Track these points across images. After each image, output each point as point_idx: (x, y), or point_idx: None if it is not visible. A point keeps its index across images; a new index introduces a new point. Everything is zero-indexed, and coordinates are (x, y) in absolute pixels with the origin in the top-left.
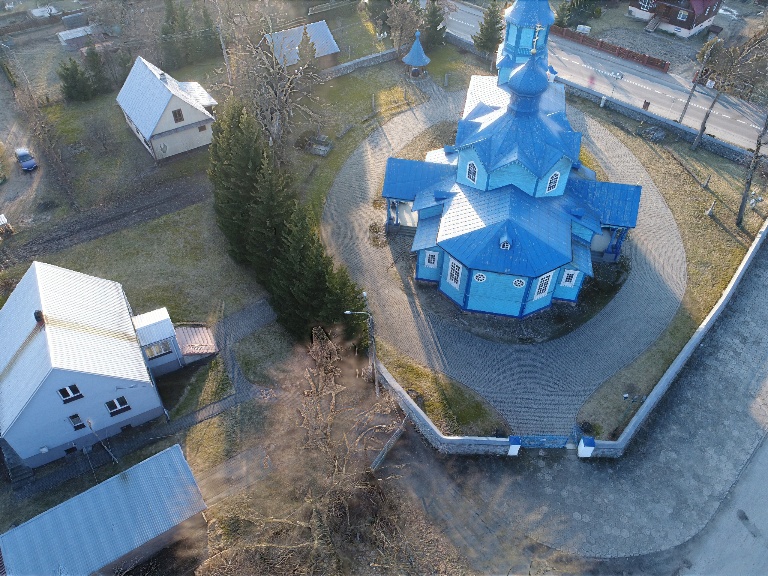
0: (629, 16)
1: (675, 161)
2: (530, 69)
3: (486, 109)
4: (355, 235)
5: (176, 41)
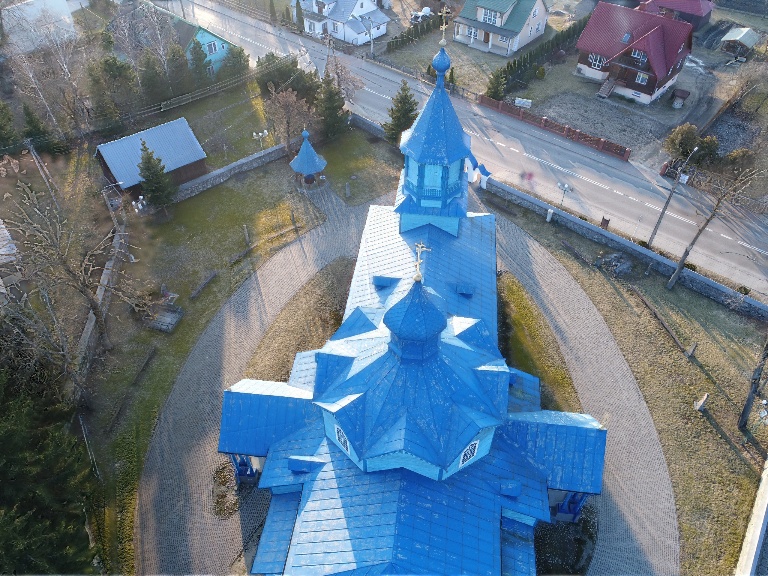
0: (578, 75)
1: (647, 310)
2: (415, 303)
3: (365, 322)
4: (191, 492)
5: None
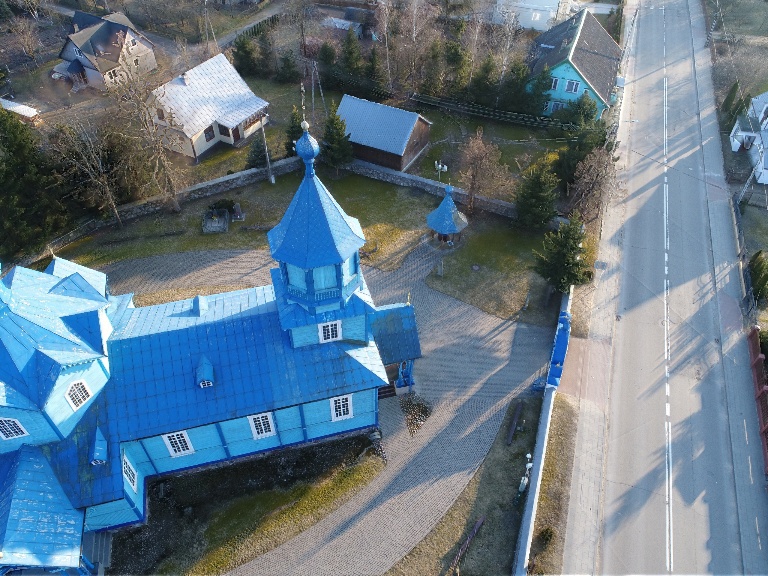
0: None
1: None
2: None
3: None
4: None
5: (336, 63)
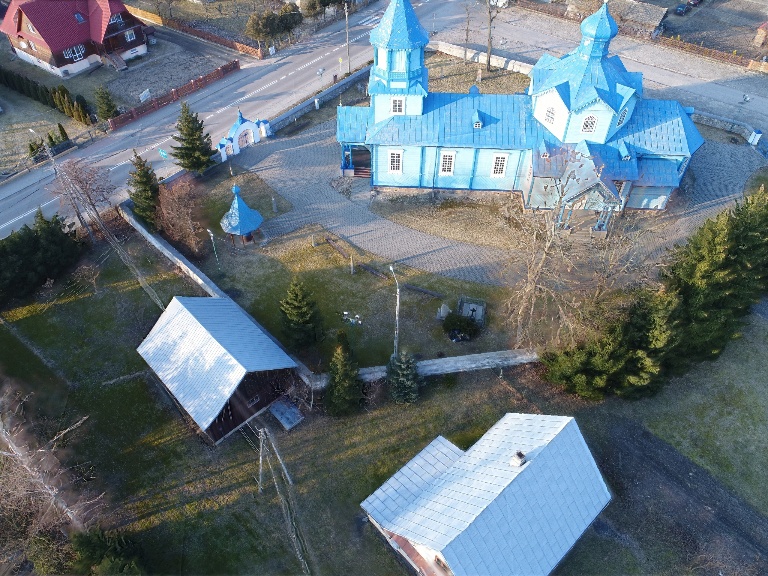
0: (72, 76)
1: None
2: None
3: (564, 86)
4: None
5: None
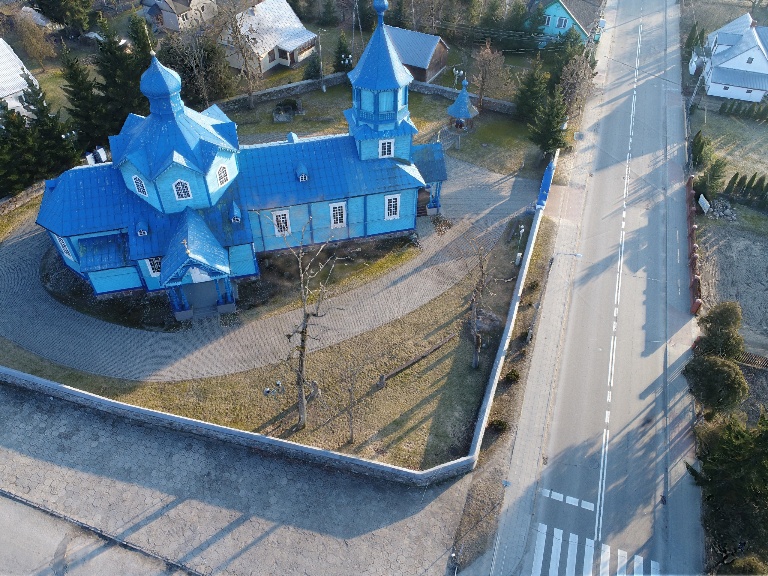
0: None
1: None
2: None
3: None
4: None
5: (370, 8)
